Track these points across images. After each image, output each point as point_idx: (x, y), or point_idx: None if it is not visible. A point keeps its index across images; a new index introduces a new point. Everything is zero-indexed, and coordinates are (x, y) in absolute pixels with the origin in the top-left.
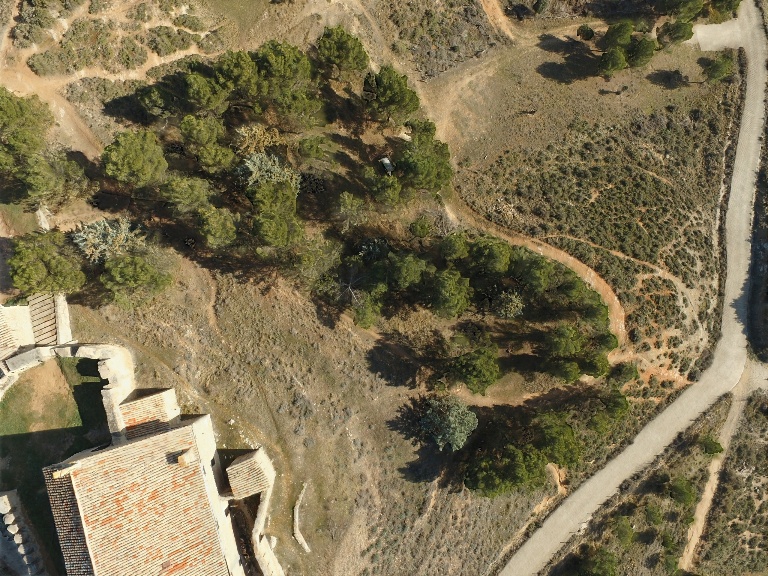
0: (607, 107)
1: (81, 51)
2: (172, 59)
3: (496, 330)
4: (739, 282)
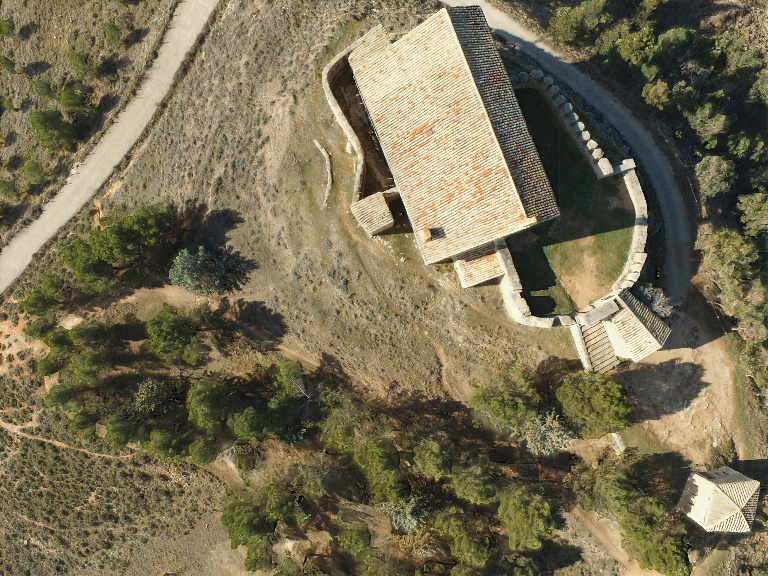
0: None
1: None
2: None
3: None
4: None
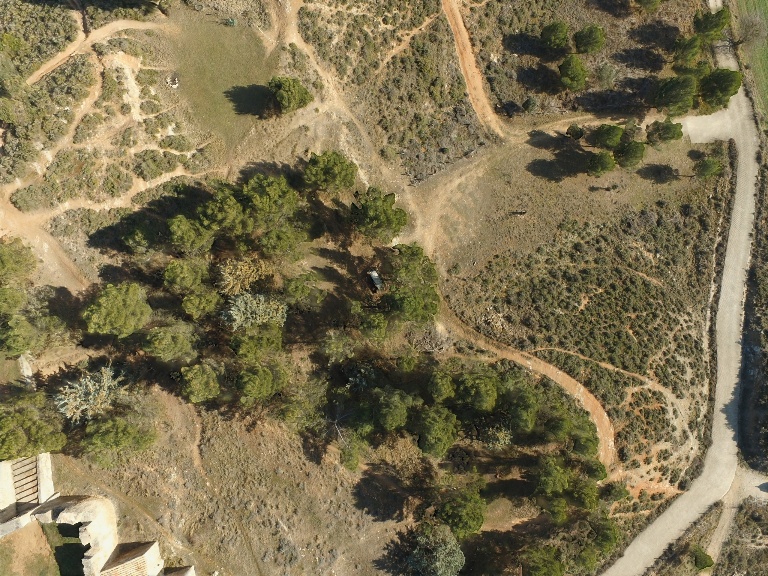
0: (597, 204)
1: (65, 183)
2: (158, 183)
3: (484, 455)
4: (729, 386)
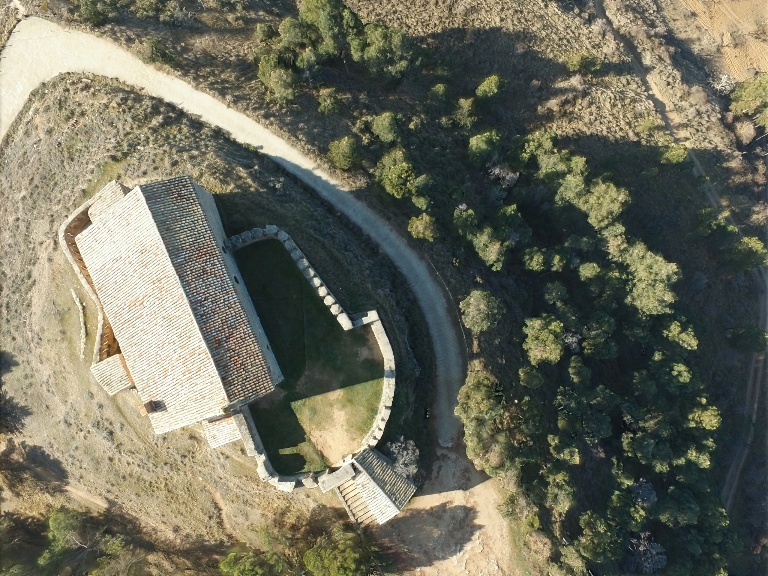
0: None
1: None
2: None
3: None
4: None
